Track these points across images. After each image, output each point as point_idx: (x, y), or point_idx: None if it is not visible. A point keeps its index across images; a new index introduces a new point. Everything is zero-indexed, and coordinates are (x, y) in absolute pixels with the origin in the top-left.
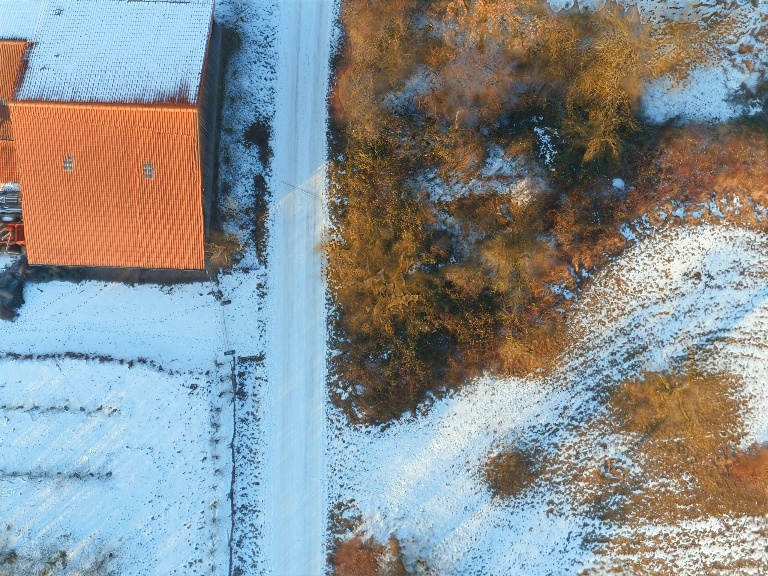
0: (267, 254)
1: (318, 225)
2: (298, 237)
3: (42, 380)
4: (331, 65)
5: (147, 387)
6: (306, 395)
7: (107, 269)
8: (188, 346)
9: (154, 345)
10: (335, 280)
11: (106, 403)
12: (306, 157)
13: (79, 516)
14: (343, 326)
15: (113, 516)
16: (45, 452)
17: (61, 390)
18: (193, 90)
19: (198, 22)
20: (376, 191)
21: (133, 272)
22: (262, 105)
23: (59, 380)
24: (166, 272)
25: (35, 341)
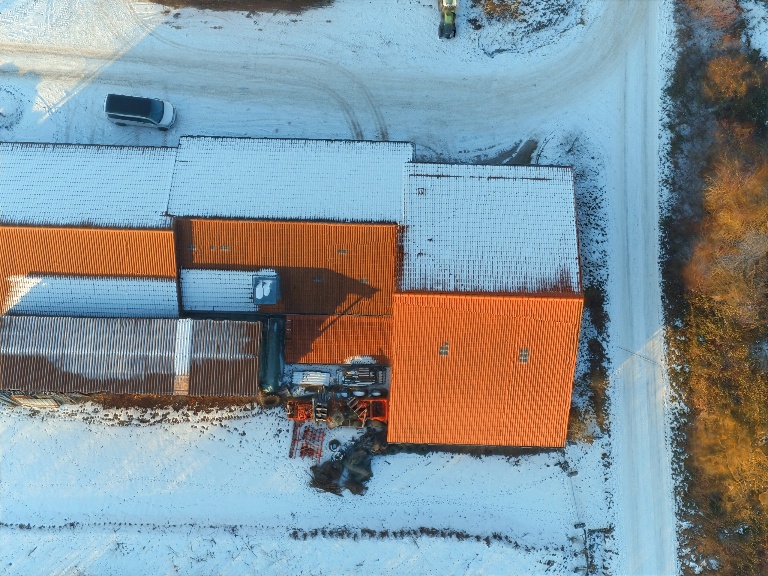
0: (610, 423)
1: (659, 392)
2: (639, 405)
3: (400, 558)
4: (662, 227)
5: (504, 564)
6: (658, 569)
7: None
8: (537, 519)
9: (504, 518)
10: (681, 450)
11: None
12: (642, 321)
13: None
14: (693, 498)
15: None
16: None
17: (419, 568)
18: (575, 277)
19: (563, 201)
20: (726, 362)
21: None
22: (596, 269)
23: (418, 558)
24: None
25: (385, 515)
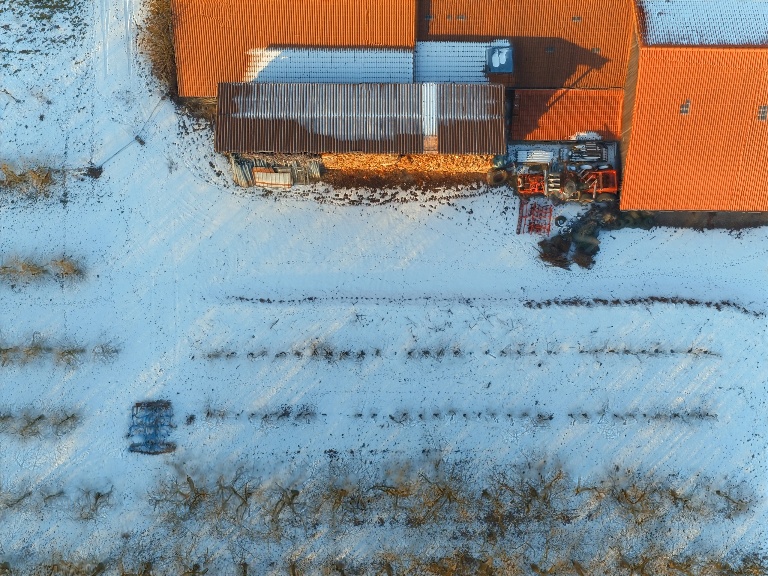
0: None
1: None
2: None
3: (633, 324)
4: None
5: (734, 329)
6: None
7: (676, 215)
8: (761, 289)
9: (728, 288)
10: None
11: (697, 345)
12: None
13: (684, 456)
14: None
15: (715, 455)
16: (641, 394)
17: (652, 333)
18: None
19: None
20: None
21: (701, 217)
22: None
23: (650, 324)
24: (733, 217)
25: (613, 287)
